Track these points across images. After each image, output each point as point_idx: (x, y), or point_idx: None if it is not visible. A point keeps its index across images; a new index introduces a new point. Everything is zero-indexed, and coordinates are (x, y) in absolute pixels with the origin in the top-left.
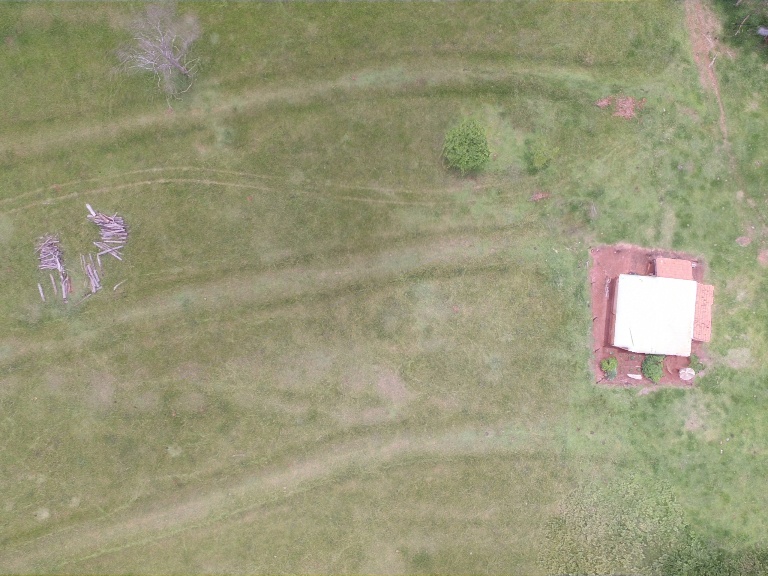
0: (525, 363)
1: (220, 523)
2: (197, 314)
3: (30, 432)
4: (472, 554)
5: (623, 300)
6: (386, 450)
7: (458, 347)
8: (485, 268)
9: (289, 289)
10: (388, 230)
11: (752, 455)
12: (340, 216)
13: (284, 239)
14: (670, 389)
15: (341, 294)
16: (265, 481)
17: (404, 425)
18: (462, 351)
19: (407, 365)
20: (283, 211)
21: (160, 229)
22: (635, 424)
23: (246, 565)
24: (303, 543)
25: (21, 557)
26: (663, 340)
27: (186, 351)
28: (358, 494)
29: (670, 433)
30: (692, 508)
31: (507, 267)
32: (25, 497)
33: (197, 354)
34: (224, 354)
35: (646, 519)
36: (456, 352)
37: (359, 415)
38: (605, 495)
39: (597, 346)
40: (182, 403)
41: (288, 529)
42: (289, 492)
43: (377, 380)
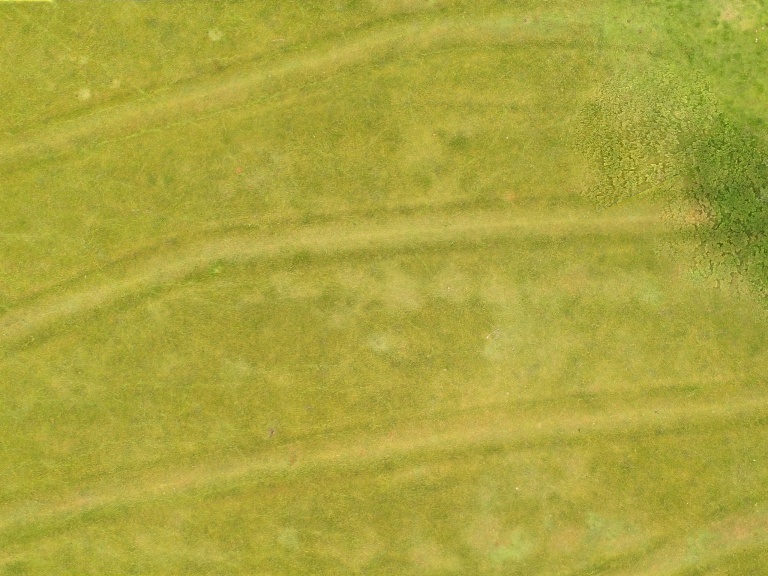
0: None
1: (259, 105)
2: None
3: (72, 15)
4: (508, 138)
5: None
6: (424, 36)
7: None
8: None
9: None
10: None
11: None
12: None
13: None
14: None
15: None
16: (304, 64)
17: (443, 12)
18: None
19: None
20: None
21: None
22: (671, 14)
23: (285, 145)
24: (341, 125)
25: (62, 134)
26: None
27: None
28: (396, 78)
29: (706, 23)
30: (726, 97)
31: None
32: (66, 78)
33: None
34: None
35: (680, 107)
36: None
37: (398, 1)
38: (640, 83)
39: None
40: None
41: (326, 112)
42: (328, 77)
43: None
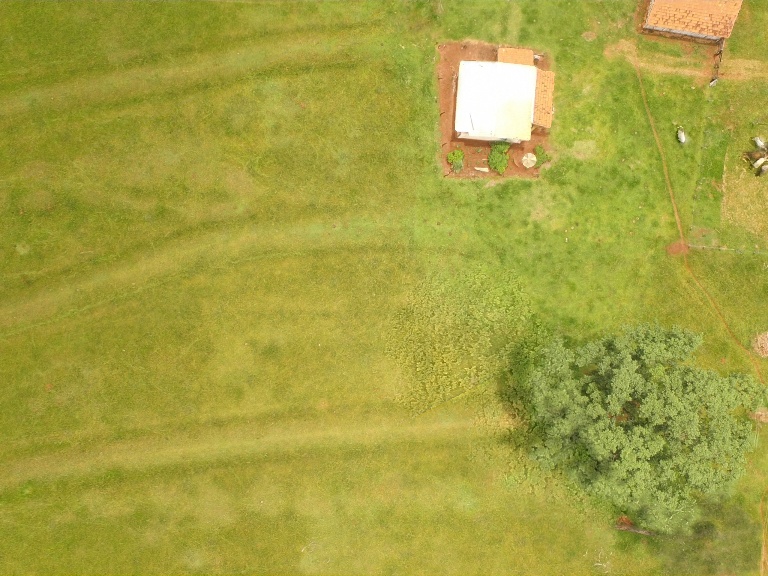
0: (372, 157)
1: (69, 319)
2: (45, 114)
3: None
4: (321, 345)
5: (464, 87)
6: (234, 244)
7: (306, 143)
8: (333, 65)
9: (137, 88)
10: (236, 29)
11: (597, 243)
12: (188, 16)
13: (131, 39)
14: (516, 181)
15: (189, 93)
16: (113, 277)
17: (252, 220)
18: (310, 146)
19: (255, 161)
20: (130, 11)
21: (7, 31)
22: (481, 215)
23: (95, 360)
24: (152, 337)
25: None
26: (503, 124)
27: (34, 150)
28: (206, 288)
29: (516, 223)
30: (538, 297)
31: (355, 64)
32: None
33: (45, 153)
34: (72, 153)
35: (493, 308)
36: (304, 147)
37: (207, 210)
38: (452, 286)
39: (445, 141)
40: (29, 201)
41: (137, 324)
42: (138, 288)
43: (225, 176)
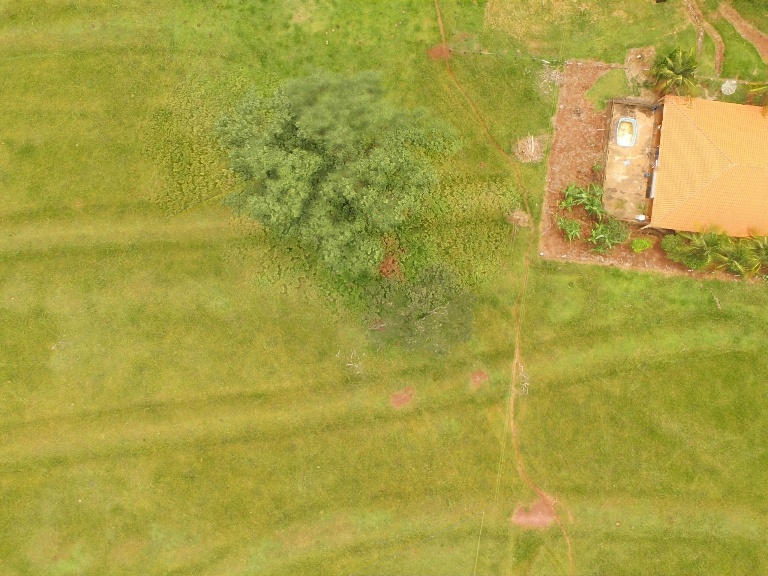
0: None
1: None
2: None
3: None
4: (78, 146)
5: None
6: None
7: None
8: None
9: None
10: None
11: (357, 45)
12: None
13: None
14: None
15: None
16: None
17: (11, 19)
18: None
19: None
20: None
21: None
22: (243, 17)
23: None
24: None
25: None
26: None
27: None
28: None
29: (277, 25)
30: (299, 100)
31: None
32: None
33: None
34: None
35: (253, 111)
36: None
37: None
38: (212, 88)
39: None
40: None
41: None
42: None
43: None
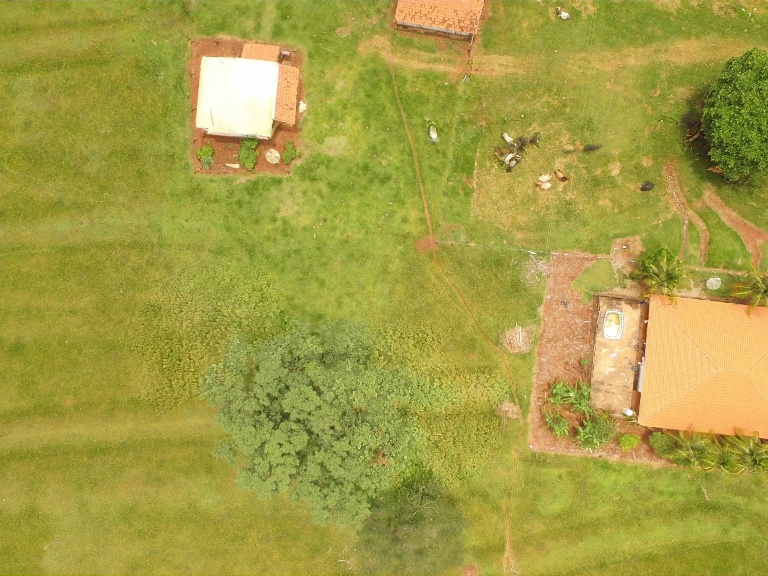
0: (122, 154)
1: None
2: None
3: None
4: (67, 343)
5: (206, 83)
6: None
7: (55, 139)
8: (85, 61)
9: None
10: None
11: (345, 239)
12: None
13: None
14: (267, 177)
15: None
16: None
17: None
18: (59, 143)
19: (4, 158)
20: None
21: None
22: (230, 211)
23: None
24: None
25: None
26: (242, 120)
27: None
28: None
29: (265, 219)
30: (287, 293)
31: (107, 61)
32: None
33: None
34: None
35: (242, 305)
36: (53, 144)
37: None
38: (201, 282)
39: (196, 137)
40: None
41: None
42: None
43: None
